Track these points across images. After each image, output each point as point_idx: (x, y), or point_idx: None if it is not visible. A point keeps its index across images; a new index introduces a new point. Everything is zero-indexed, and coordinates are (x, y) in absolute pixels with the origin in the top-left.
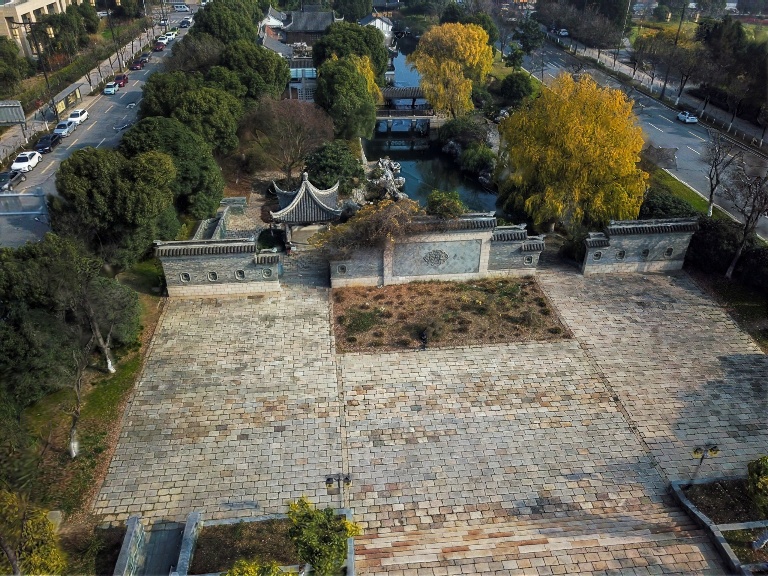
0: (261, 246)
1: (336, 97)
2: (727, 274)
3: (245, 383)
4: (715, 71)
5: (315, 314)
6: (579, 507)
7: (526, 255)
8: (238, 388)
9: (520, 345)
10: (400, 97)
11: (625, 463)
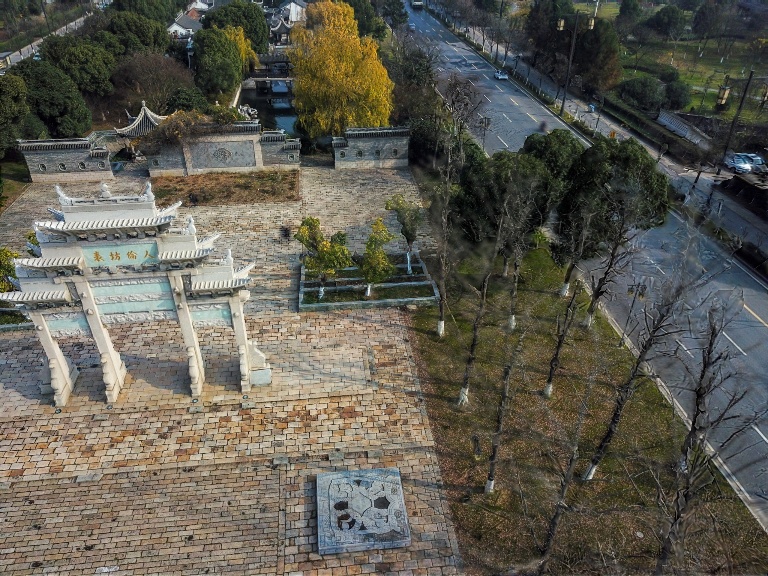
0: (115, 157)
1: (202, 56)
2: (433, 166)
3: None
4: (520, 37)
5: (131, 190)
6: None
7: (289, 153)
8: None
9: (262, 204)
10: (274, 61)
11: (285, 254)
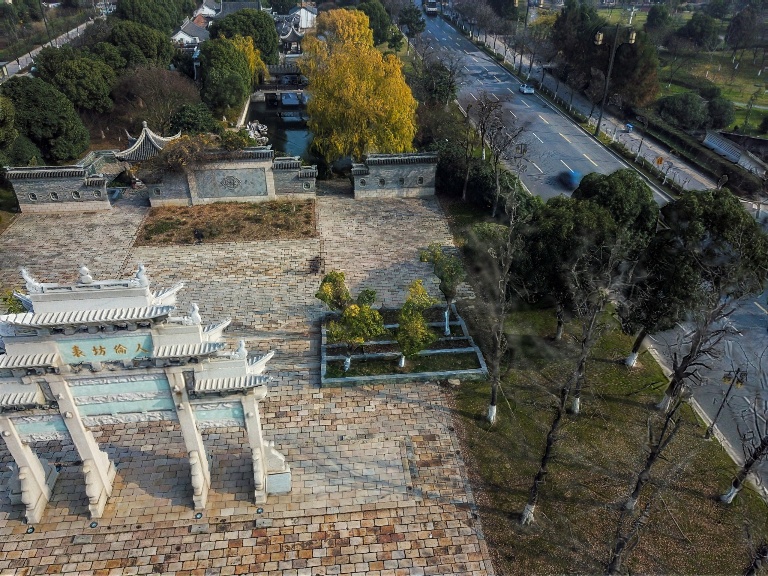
0: (114, 182)
1: (209, 69)
2: (463, 196)
3: (55, 263)
4: (548, 49)
5: (130, 223)
6: (253, 327)
7: (304, 181)
8: (48, 266)
9: (274, 241)
10: (285, 73)
11: (302, 305)
